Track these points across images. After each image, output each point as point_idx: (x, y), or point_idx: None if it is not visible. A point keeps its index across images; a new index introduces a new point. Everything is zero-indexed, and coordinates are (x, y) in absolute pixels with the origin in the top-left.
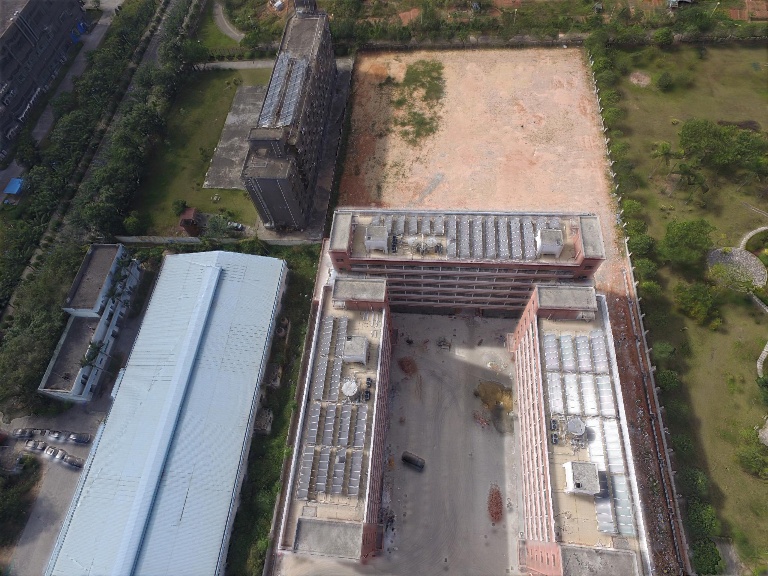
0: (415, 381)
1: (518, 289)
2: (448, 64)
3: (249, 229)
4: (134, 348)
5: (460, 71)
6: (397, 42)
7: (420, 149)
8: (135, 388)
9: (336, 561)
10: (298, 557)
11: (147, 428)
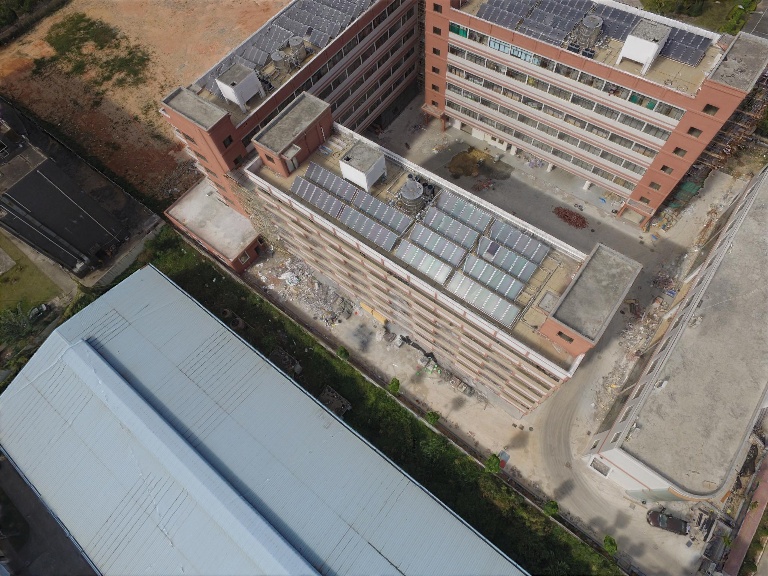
0: None
1: (395, 49)
2: (85, 8)
3: (60, 300)
4: (81, 545)
5: (105, 5)
6: (3, 24)
7: (153, 79)
8: (149, 571)
9: (553, 406)
10: (526, 450)
11: (231, 573)
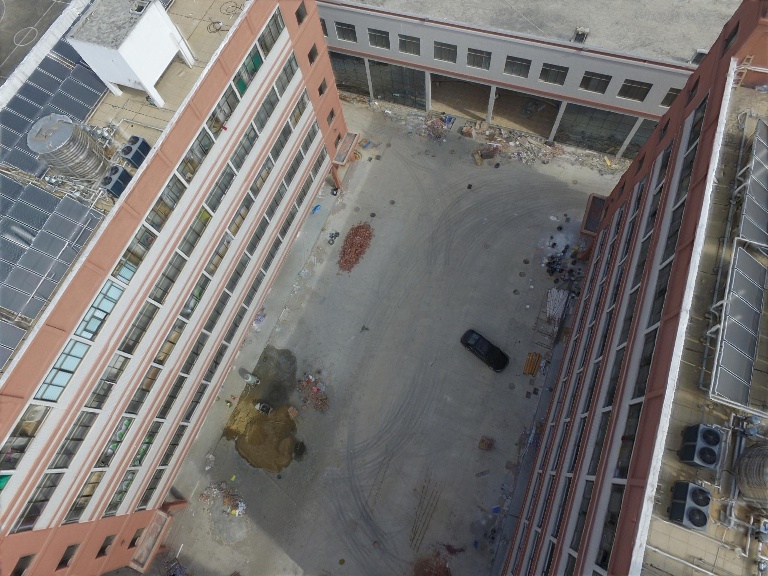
0: (430, 534)
1: None
2: None
3: None
4: None
5: None
6: None
7: None
8: None
9: None
10: None
11: None
